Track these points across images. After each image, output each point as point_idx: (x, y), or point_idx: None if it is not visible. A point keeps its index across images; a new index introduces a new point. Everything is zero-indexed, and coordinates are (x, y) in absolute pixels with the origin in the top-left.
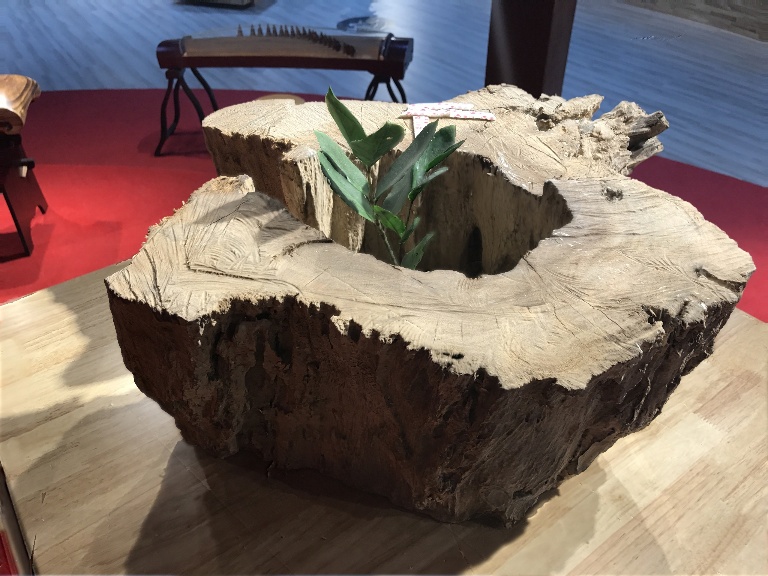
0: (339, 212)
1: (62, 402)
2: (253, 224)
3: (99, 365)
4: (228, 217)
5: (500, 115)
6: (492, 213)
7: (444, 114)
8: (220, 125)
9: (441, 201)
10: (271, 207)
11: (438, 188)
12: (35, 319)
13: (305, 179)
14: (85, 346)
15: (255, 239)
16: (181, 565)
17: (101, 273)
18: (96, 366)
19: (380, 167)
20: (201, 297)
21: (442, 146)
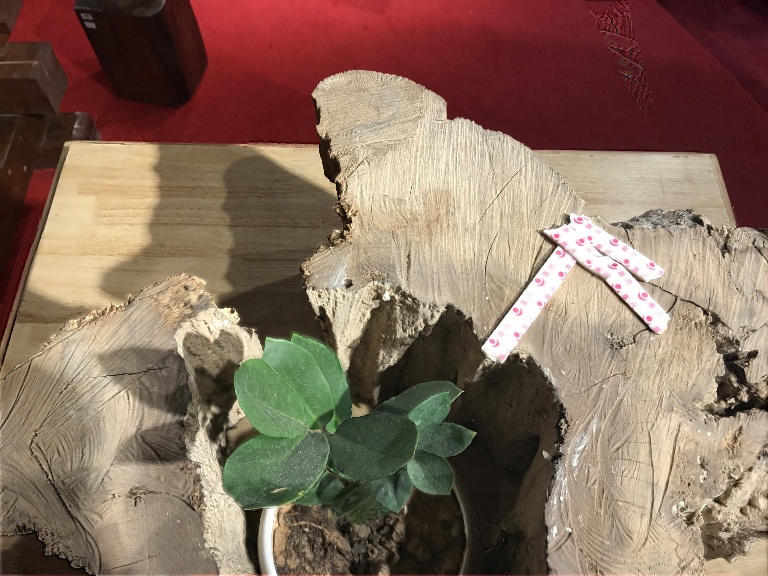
0: (377, 325)
1: (87, 306)
2: (136, 417)
3: (140, 280)
4: (128, 378)
5: (680, 324)
6: (535, 478)
7: (599, 273)
8: (328, 107)
9: (512, 385)
10: (172, 402)
11: (512, 375)
12: (126, 182)
13: (317, 304)
14: (141, 248)
15: (118, 448)
16: (58, 564)
17: (213, 152)
18: (136, 280)
19: (443, 316)
20: (6, 506)
21: (447, 439)
